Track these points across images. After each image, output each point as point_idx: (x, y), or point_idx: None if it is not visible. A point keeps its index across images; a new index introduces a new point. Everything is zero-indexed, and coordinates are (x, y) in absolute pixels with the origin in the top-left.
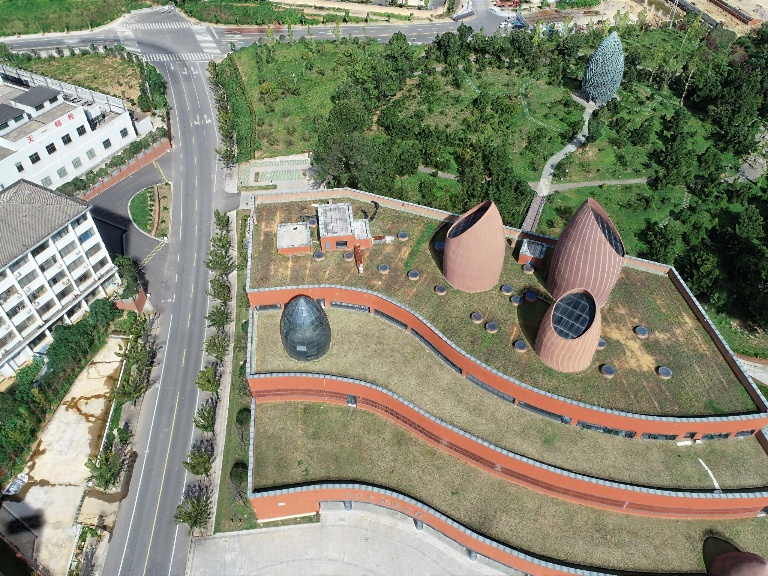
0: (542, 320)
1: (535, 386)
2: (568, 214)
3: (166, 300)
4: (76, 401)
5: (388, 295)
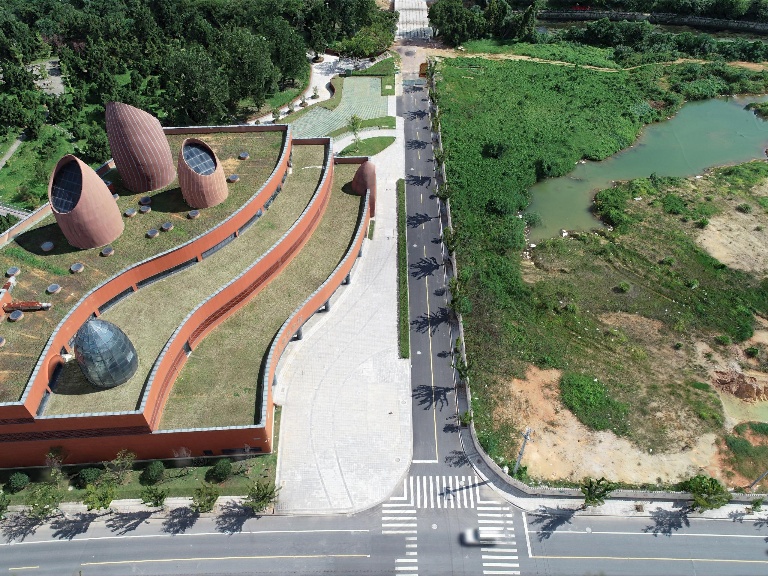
0: (187, 184)
1: None
2: (24, 196)
3: None
4: None
5: None
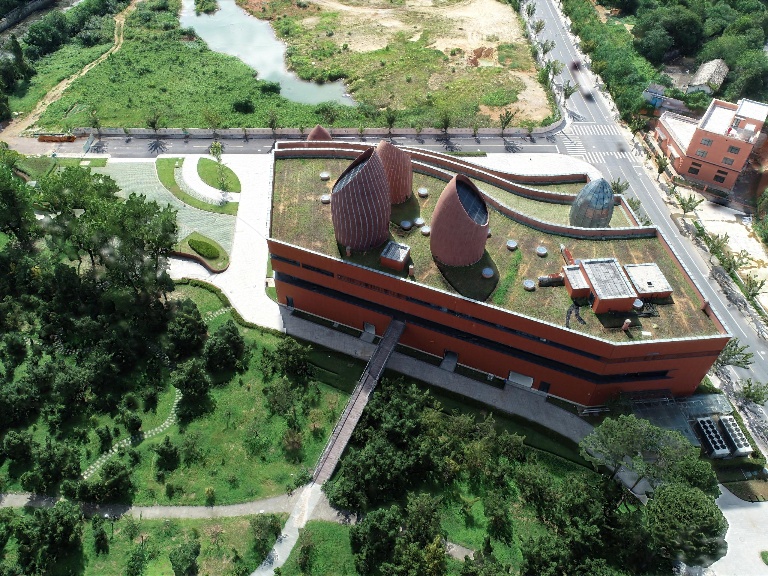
0: None
1: (417, 174)
2: (288, 449)
3: (767, 353)
4: (760, 265)
5: (532, 231)
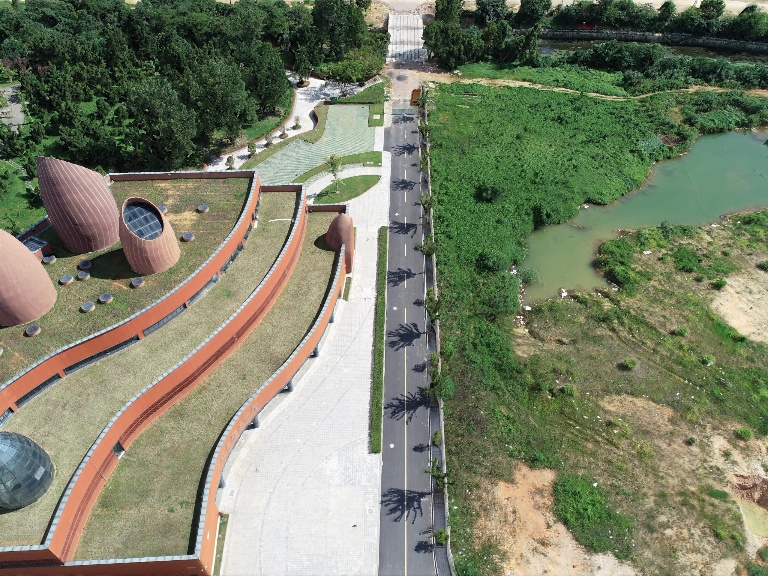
0: (129, 250)
1: None
2: None
3: None
4: None
5: None
